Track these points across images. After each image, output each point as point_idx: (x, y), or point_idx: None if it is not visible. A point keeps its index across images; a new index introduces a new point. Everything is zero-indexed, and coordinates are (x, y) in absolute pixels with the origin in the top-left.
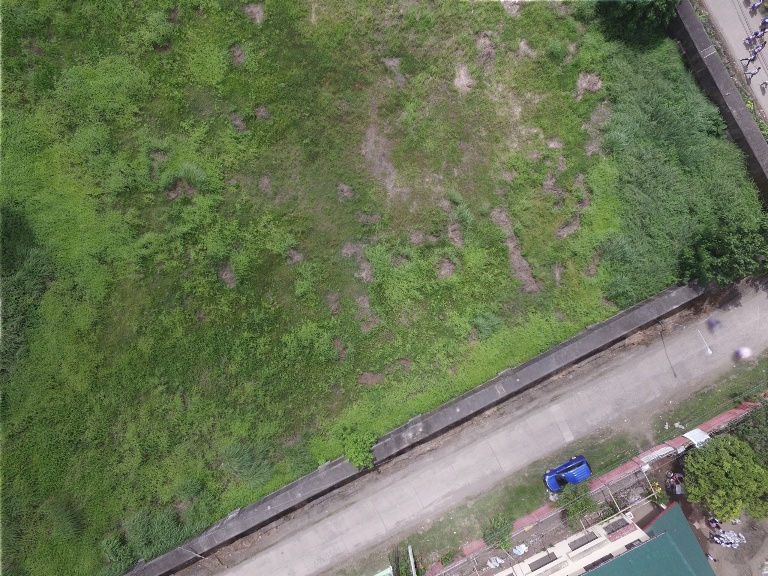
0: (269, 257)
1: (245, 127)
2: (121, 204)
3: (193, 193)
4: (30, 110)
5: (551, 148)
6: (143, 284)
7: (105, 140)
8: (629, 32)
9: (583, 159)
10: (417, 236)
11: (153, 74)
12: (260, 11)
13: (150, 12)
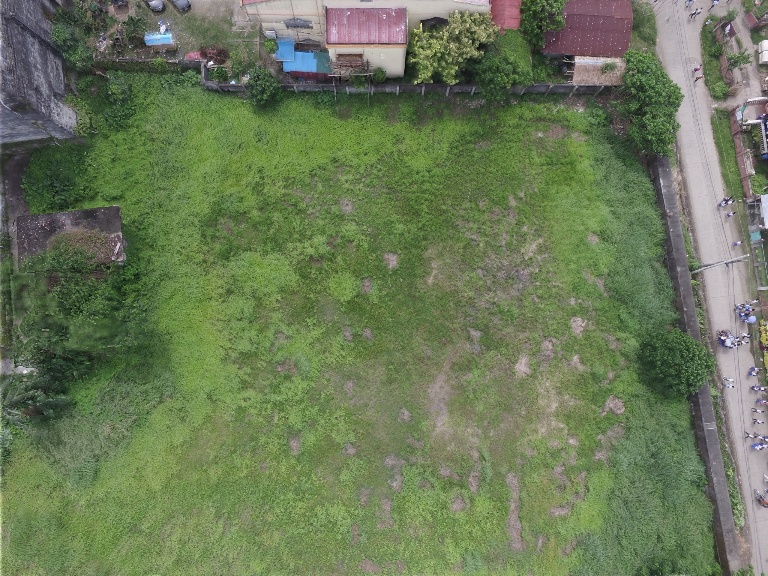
0: (331, 442)
1: (351, 339)
2: (240, 360)
3: (295, 372)
4: (205, 269)
5: (570, 443)
6: (231, 425)
7: (249, 312)
8: (657, 383)
9: (591, 461)
10: (445, 470)
11: (301, 277)
12: (395, 260)
13: (317, 232)
